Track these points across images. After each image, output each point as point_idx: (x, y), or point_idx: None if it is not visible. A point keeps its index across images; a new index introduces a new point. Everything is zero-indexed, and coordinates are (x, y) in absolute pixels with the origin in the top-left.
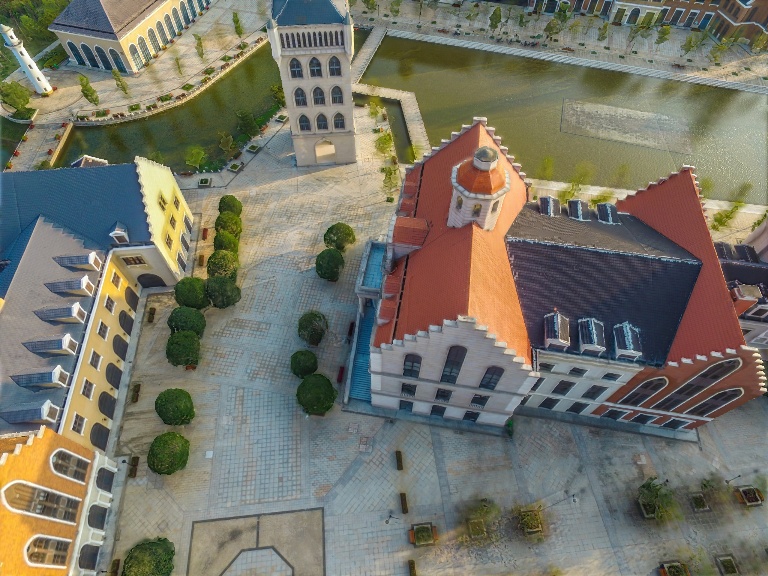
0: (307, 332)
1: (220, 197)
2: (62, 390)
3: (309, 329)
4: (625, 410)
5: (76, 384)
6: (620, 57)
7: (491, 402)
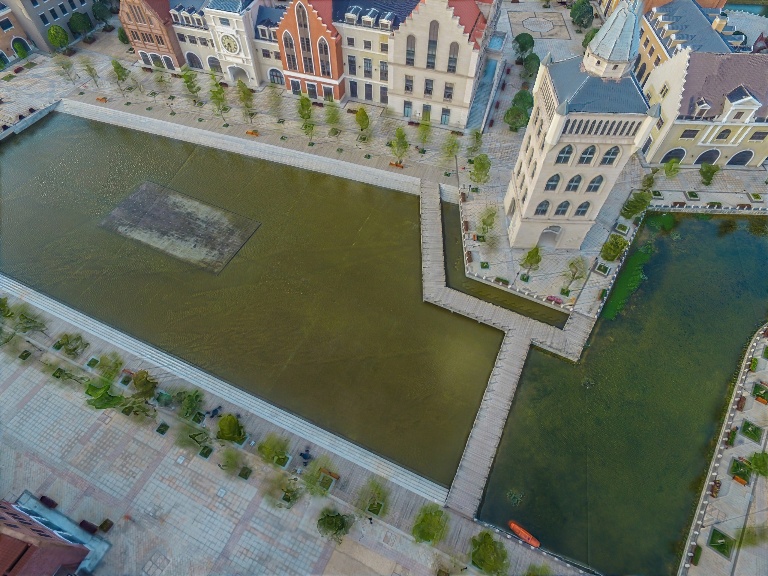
0: None
1: (633, 180)
2: None
3: None
4: None
5: None
6: (63, 344)
7: None
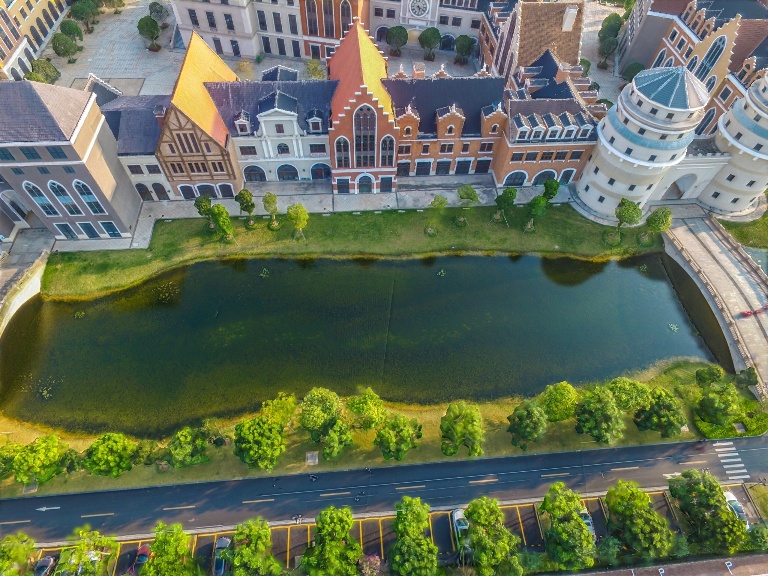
0: (153, 10)
1: None
2: (8, 0)
3: (154, 8)
4: (317, 44)
5: (16, 3)
6: None
7: (235, 23)
